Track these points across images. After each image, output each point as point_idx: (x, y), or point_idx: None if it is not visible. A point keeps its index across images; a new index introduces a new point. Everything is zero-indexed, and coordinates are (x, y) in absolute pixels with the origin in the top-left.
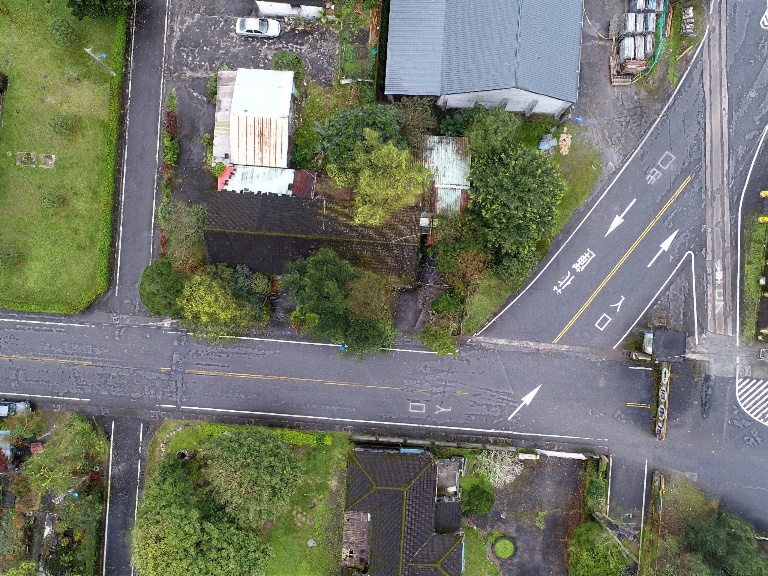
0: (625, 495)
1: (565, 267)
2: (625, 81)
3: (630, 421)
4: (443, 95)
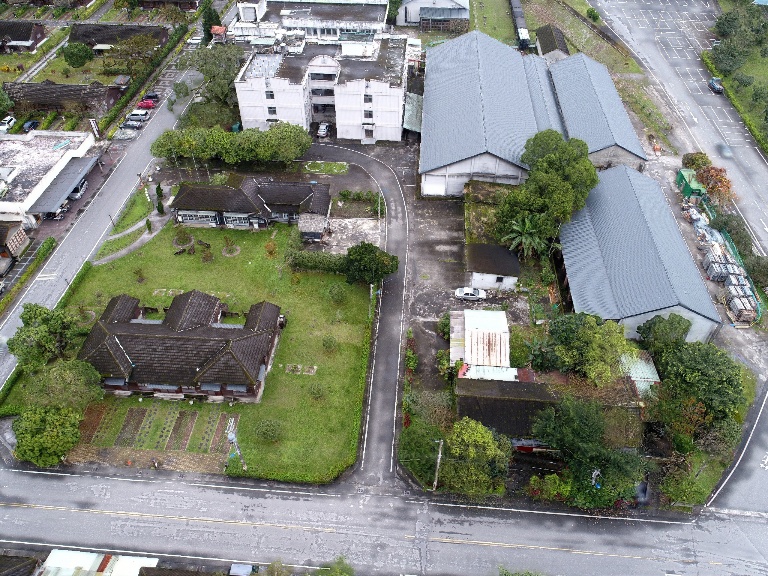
0: None
1: (762, 448)
2: (744, 325)
3: None
4: (620, 321)
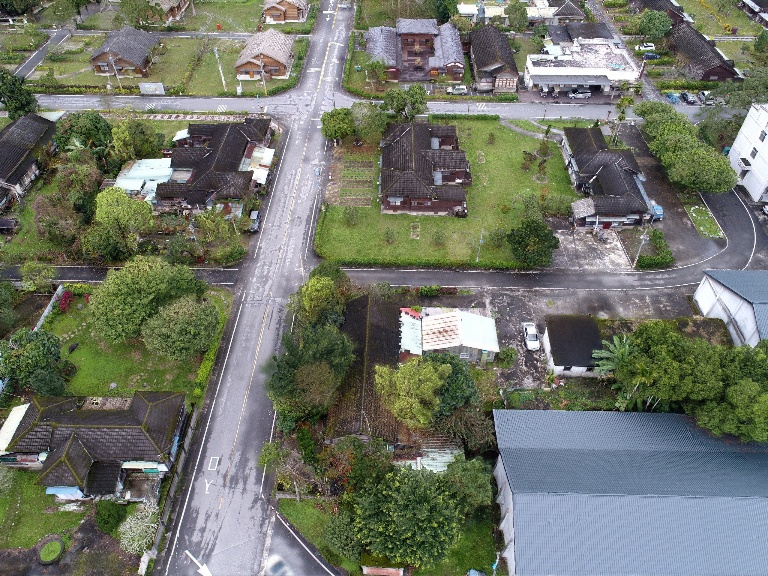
0: None
1: None
2: None
3: None
4: None
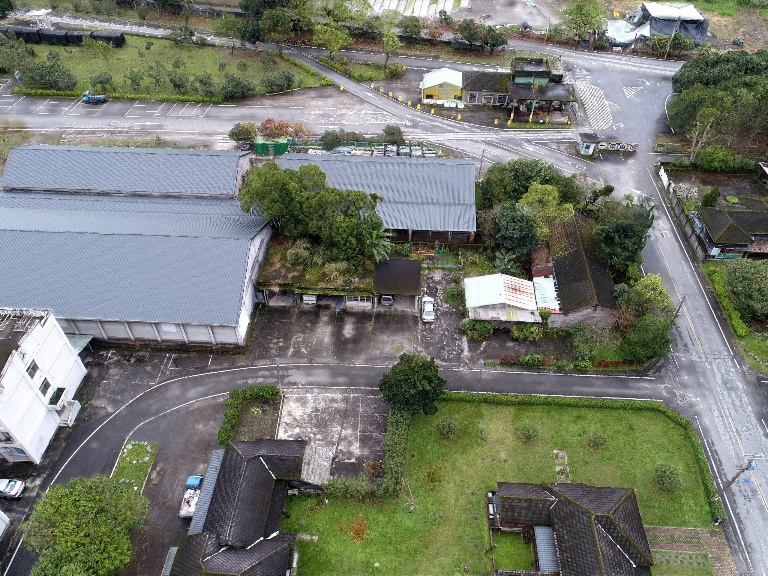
0: (673, 160)
1: None
2: None
3: (632, 159)
4: None
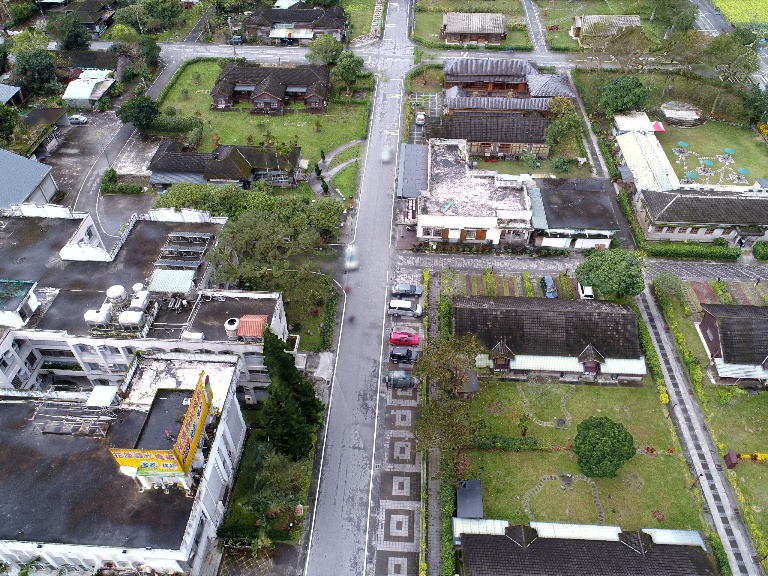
0: None
1: None
2: None
3: None
4: None
